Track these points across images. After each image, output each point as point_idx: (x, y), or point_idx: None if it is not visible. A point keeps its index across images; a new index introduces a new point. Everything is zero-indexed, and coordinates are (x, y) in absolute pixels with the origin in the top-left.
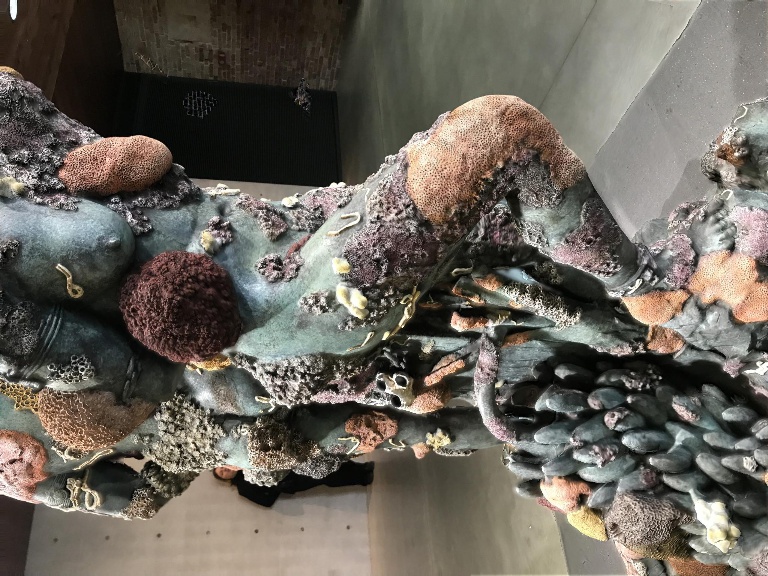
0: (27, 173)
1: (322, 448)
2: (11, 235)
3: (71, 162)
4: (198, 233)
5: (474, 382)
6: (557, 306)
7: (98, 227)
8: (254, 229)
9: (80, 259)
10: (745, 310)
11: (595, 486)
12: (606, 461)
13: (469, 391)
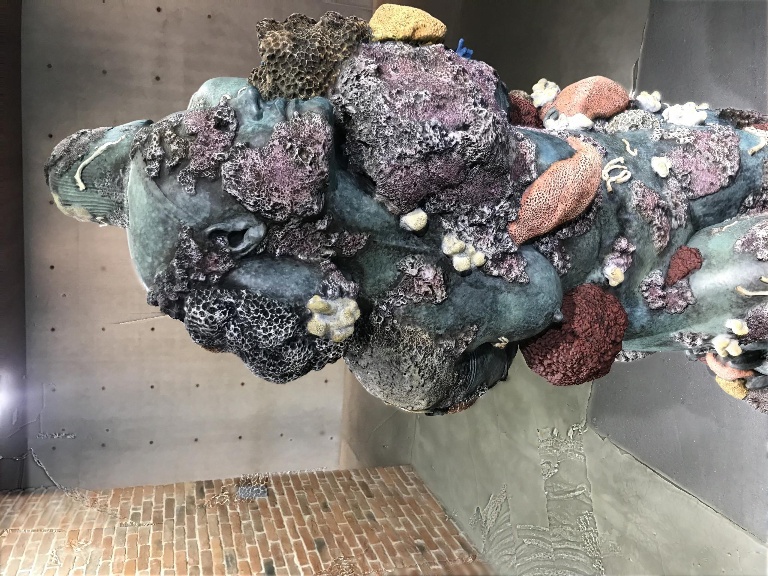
0: (486, 238)
1: None
2: (471, 319)
3: (524, 214)
4: (602, 258)
5: None
6: None
7: (547, 303)
8: (647, 242)
9: (524, 333)
10: None
11: (758, 373)
12: None
13: None
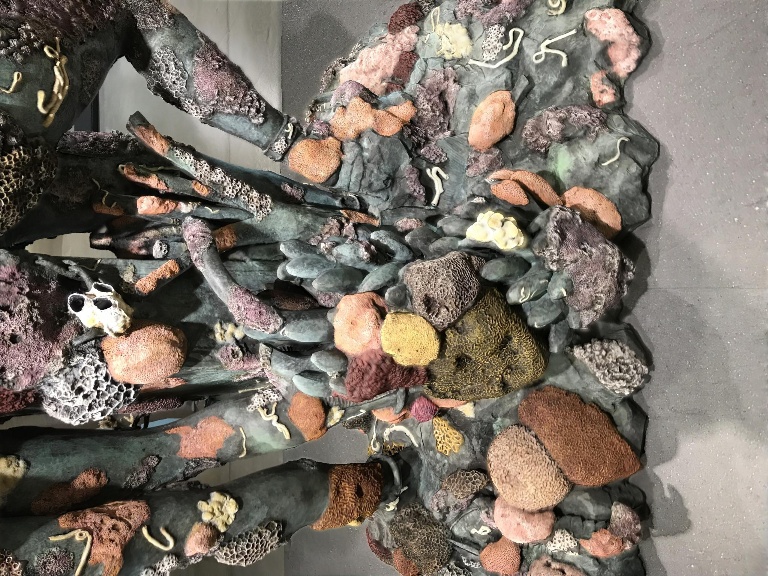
0: None
1: (23, 563)
2: None
3: None
4: None
5: (193, 258)
6: (241, 182)
7: None
8: None
9: None
10: (382, 128)
11: (382, 293)
12: (368, 249)
13: (211, 351)
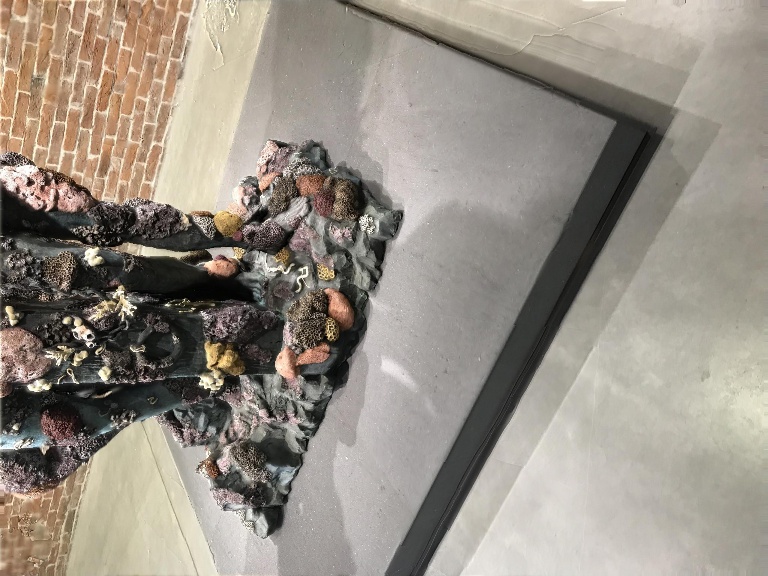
0: None
1: None
2: None
3: None
4: None
5: None
6: None
7: None
8: None
9: None
10: None
11: None
12: None
13: None
